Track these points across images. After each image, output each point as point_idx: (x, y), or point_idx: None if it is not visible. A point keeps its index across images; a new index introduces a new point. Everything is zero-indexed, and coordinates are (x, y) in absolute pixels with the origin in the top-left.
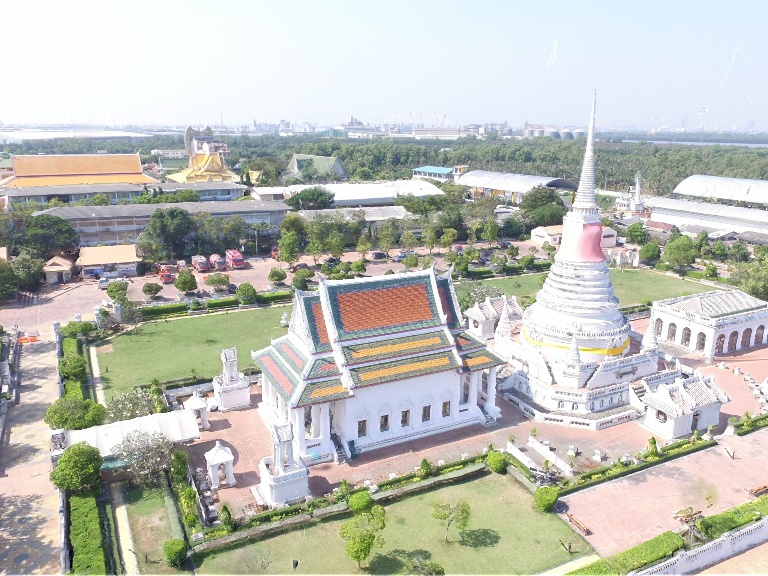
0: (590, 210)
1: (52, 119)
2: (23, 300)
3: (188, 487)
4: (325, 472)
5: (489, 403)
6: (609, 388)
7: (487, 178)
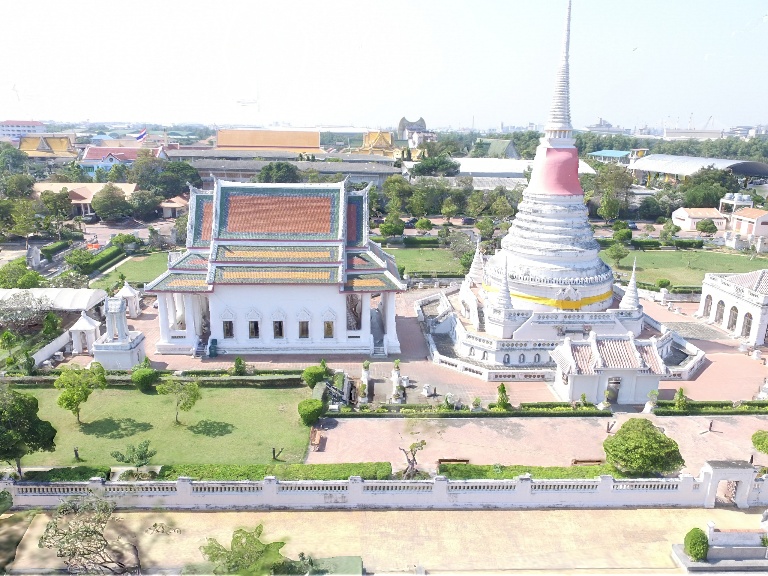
0: (560, 132)
1: (241, 95)
2: (130, 225)
3: (43, 343)
4: (174, 361)
5: (387, 335)
6: (533, 341)
7: (663, 161)
